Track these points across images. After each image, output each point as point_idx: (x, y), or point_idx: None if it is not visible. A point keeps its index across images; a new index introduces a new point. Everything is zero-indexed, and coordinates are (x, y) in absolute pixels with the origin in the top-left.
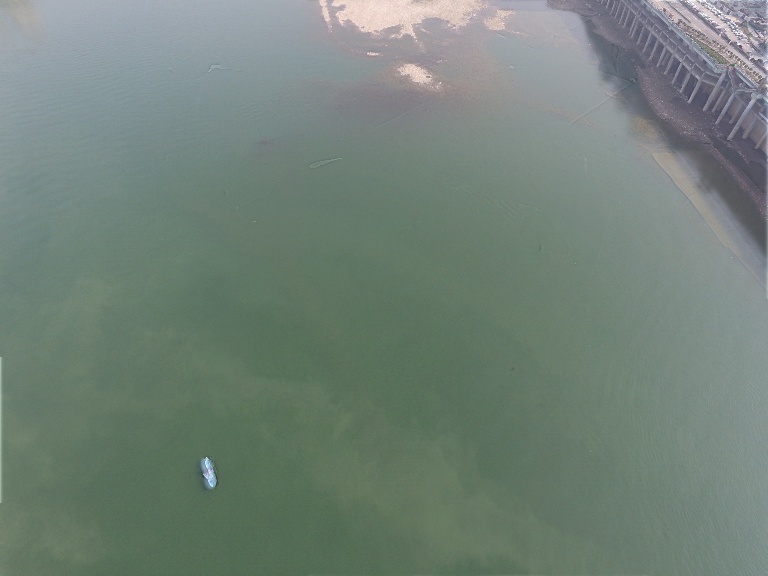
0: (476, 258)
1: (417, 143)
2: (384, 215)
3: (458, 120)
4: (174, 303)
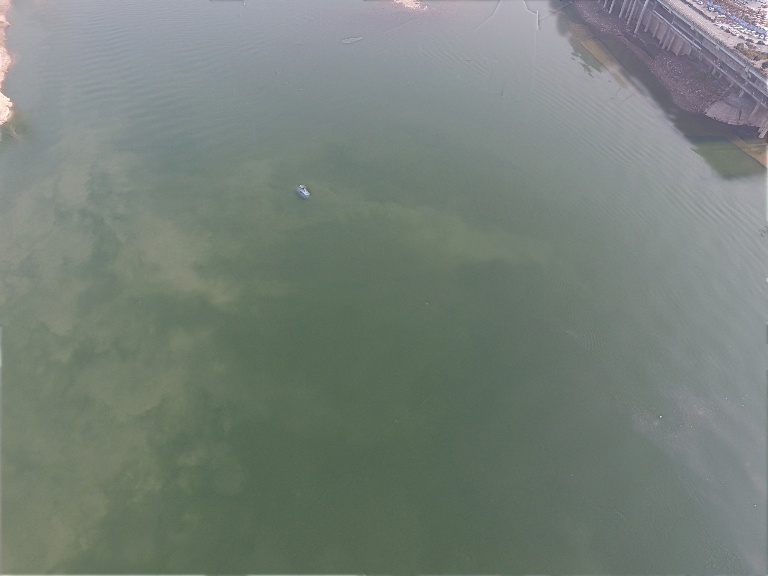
0: (459, 100)
1: (412, 43)
2: (394, 80)
3: (441, 28)
4: (261, 119)
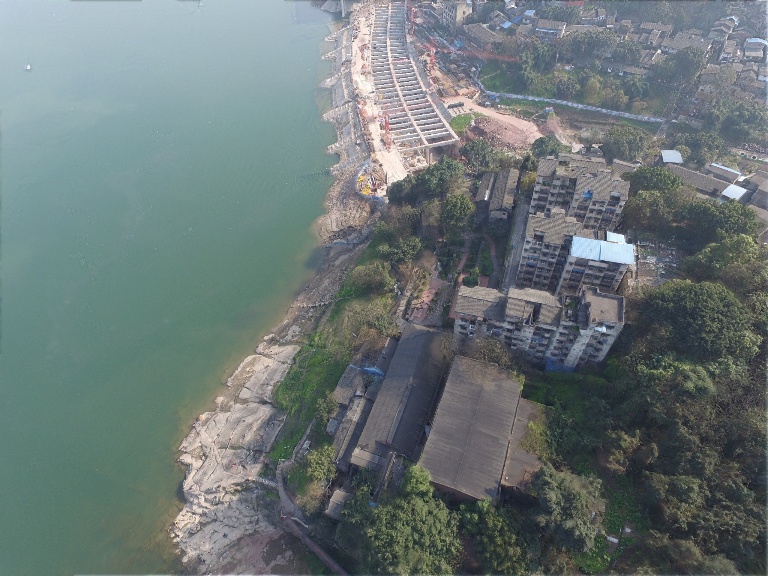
0: (170, 17)
1: None
2: None
3: None
4: (17, 35)
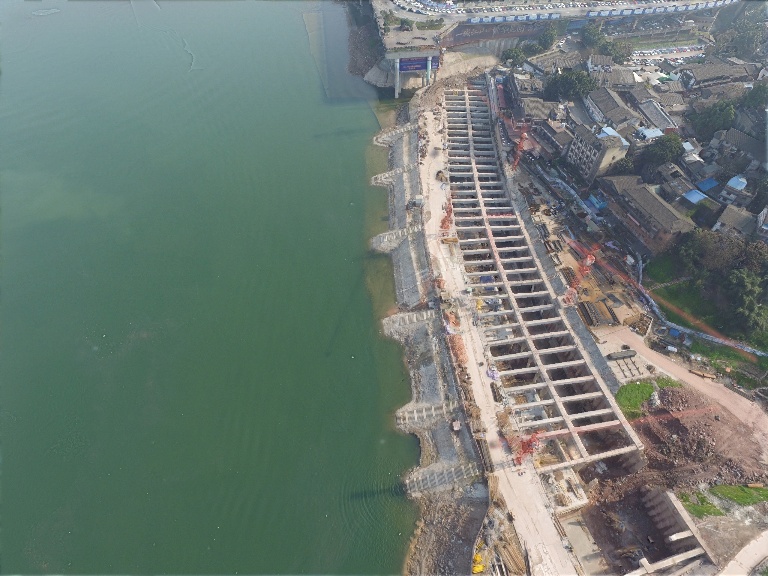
0: (151, 69)
1: None
2: (98, 51)
3: (182, 2)
4: None
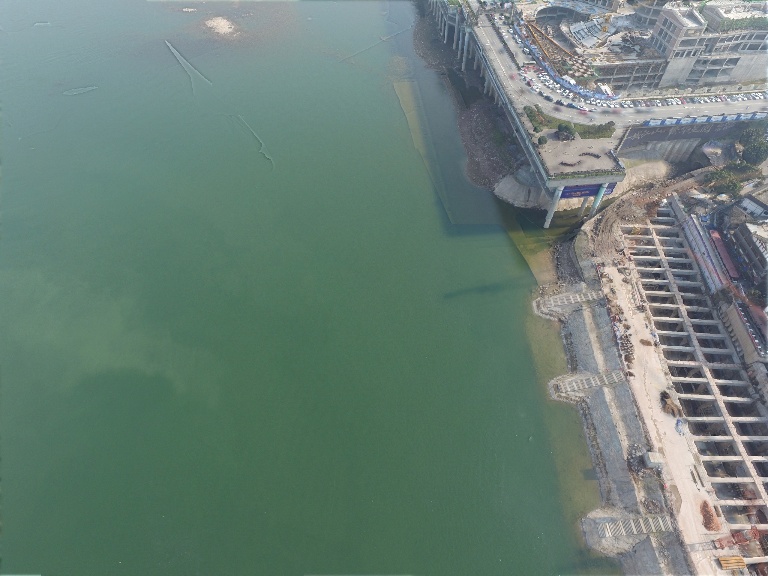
0: (211, 166)
1: None
2: (144, 137)
3: (241, 62)
4: None
